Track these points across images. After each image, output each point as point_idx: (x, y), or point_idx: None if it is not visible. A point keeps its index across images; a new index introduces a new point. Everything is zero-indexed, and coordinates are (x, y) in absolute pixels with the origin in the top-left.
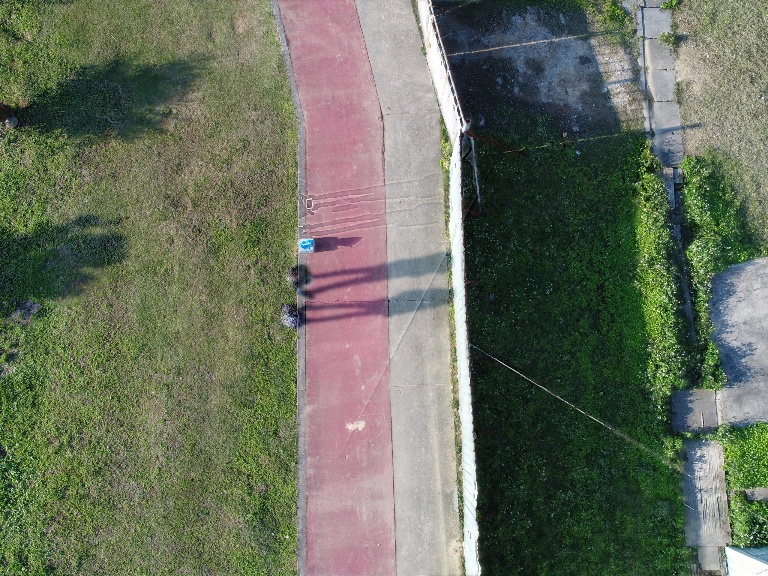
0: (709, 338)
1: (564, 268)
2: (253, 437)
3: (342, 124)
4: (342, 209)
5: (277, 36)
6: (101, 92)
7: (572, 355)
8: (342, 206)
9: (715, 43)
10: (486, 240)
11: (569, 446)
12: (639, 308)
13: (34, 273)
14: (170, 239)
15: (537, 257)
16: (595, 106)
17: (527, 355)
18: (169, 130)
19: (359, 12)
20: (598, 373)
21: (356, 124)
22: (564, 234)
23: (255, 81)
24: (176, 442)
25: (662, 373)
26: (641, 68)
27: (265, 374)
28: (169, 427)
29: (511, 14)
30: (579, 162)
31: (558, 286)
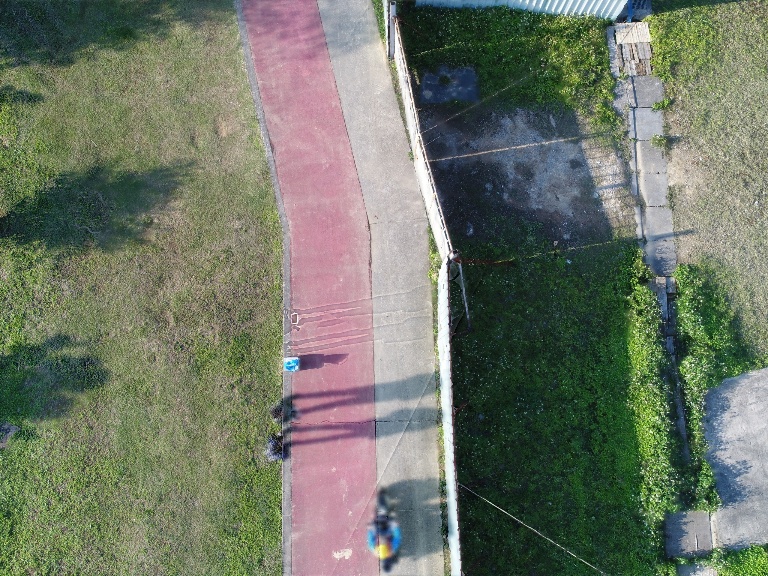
0: (703, 457)
1: (555, 385)
2: (237, 567)
3: (328, 234)
4: (328, 324)
5: (261, 141)
6: (81, 200)
7: (563, 477)
8: (328, 321)
9: (708, 145)
10: (475, 358)
11: (561, 574)
12: (632, 428)
13: (12, 393)
14: (152, 357)
15: (527, 373)
16: (586, 212)
17: (518, 478)
18: (151, 241)
19: (345, 115)
20: (590, 495)
21: (342, 234)
22: (555, 349)
23: (239, 188)
24: (158, 573)
25: (655, 498)
26: (633, 172)
27: (249, 500)
28: (151, 557)
29: (500, 116)
30: (570, 272)
31: (549, 405)
